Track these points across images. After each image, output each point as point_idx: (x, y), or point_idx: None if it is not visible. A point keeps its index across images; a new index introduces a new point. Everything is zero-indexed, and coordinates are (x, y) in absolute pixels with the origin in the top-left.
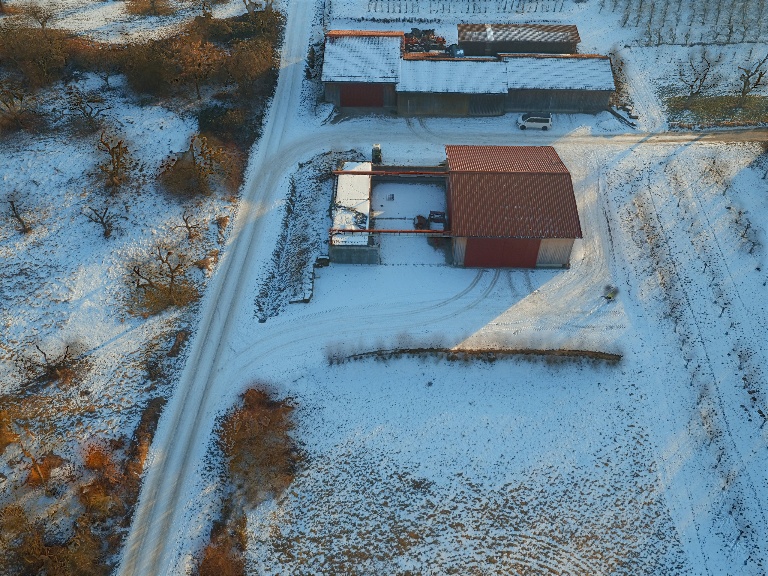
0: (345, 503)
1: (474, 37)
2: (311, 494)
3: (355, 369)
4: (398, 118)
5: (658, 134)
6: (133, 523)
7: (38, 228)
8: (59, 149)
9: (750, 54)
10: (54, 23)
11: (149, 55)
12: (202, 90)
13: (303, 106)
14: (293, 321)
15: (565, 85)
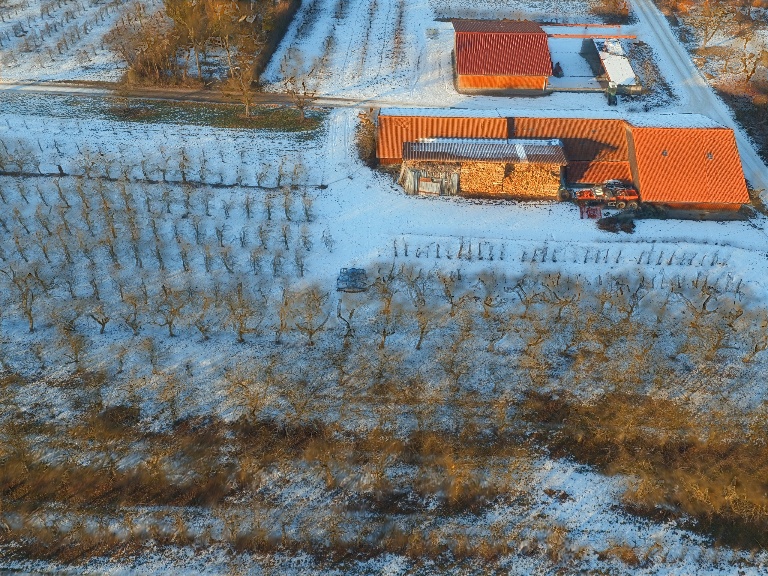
0: (565, 5)
1: (541, 148)
2: None
3: None
4: None
5: (346, 106)
6: (652, 3)
7: None
8: None
9: (183, 152)
10: None
11: None
12: None
13: None
14: None
15: (435, 109)
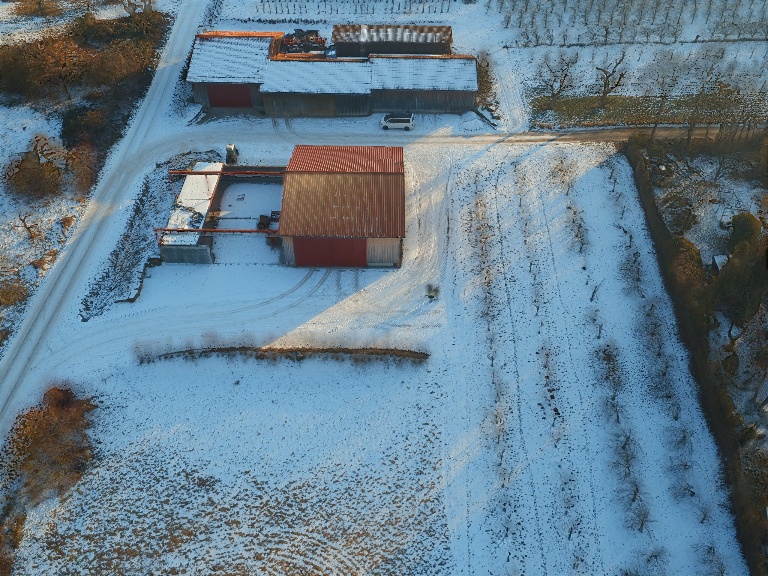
0: (127, 501)
1: (347, 38)
2: (96, 492)
3: (165, 368)
4: (265, 118)
5: (517, 134)
6: None
7: None
8: None
9: None
10: None
11: (15, 56)
12: (74, 91)
13: (172, 107)
14: (115, 320)
15: (428, 86)
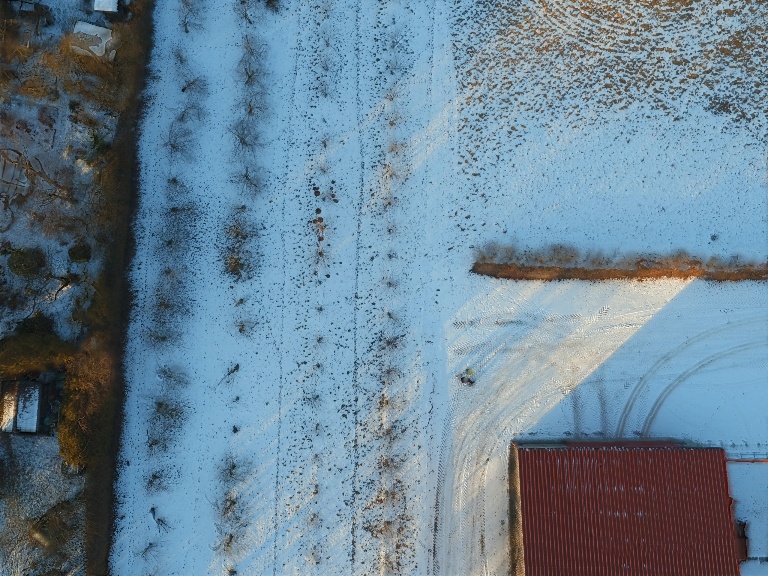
0: None
1: None
2: None
3: None
4: None
5: None
6: None
7: None
8: None
9: None
10: None
11: None
12: None
13: None
14: None
15: None
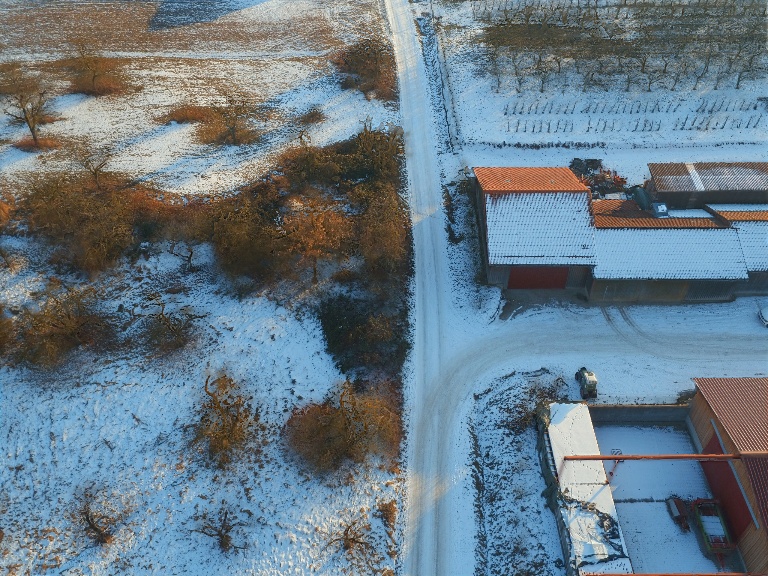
0: None
1: (677, 185)
2: None
3: None
4: (591, 308)
5: None
6: None
7: (120, 532)
8: (135, 379)
9: None
10: (106, 162)
11: (251, 231)
12: None
13: (458, 291)
14: None
15: None
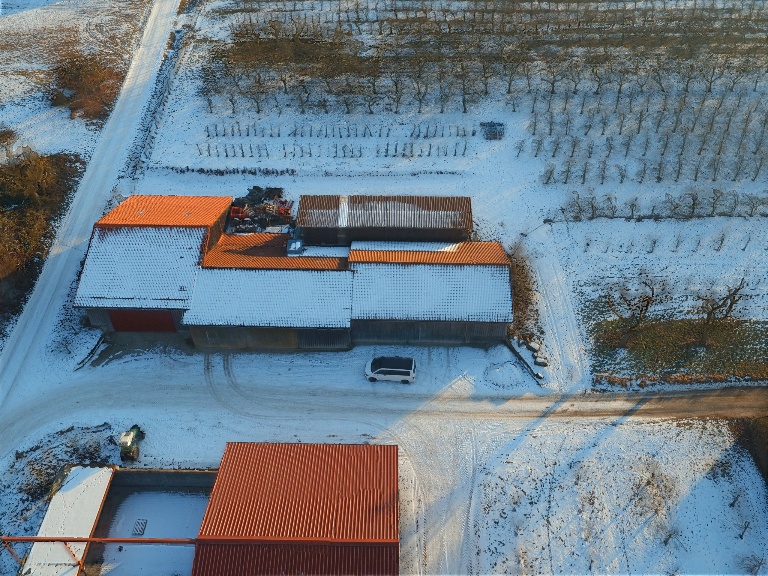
0: None
1: (319, 220)
2: None
3: None
4: (194, 355)
5: (575, 397)
6: None
7: None
8: None
9: (721, 242)
10: None
11: None
12: None
13: (57, 333)
14: None
15: (438, 313)
